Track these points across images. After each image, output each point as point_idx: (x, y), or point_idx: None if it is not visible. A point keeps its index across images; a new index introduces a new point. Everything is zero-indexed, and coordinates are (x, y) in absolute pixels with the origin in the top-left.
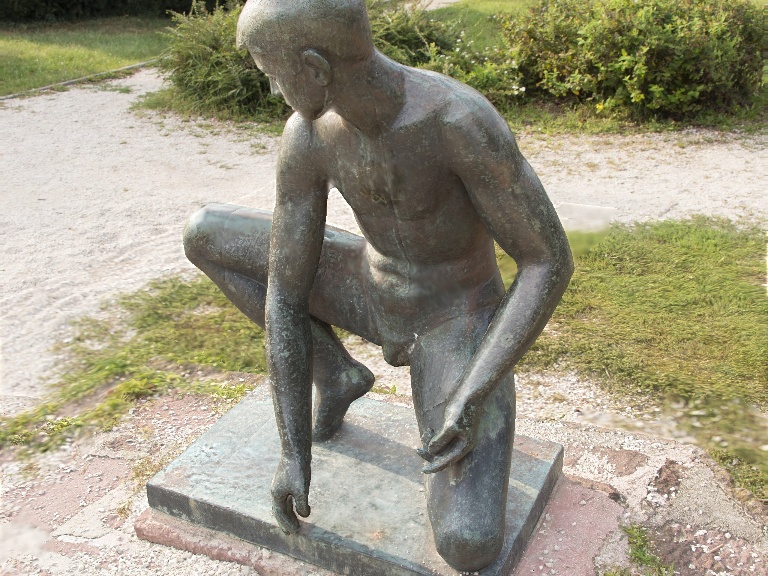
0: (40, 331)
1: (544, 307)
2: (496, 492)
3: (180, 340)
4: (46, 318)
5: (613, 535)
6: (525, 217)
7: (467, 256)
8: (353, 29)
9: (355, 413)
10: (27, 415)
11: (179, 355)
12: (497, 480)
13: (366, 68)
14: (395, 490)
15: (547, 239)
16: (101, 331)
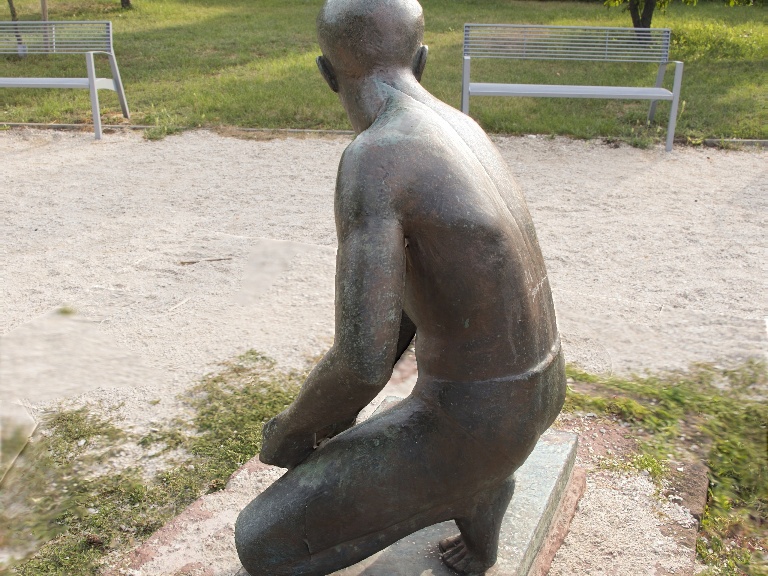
0: (721, 349)
1: (313, 382)
2: (266, 520)
3: (765, 428)
4: (744, 345)
5: None
6: (336, 282)
7: (426, 334)
8: (339, 45)
9: (516, 492)
10: (575, 372)
11: (727, 430)
12: (274, 514)
13: (358, 87)
14: None
15: (338, 318)
16: (746, 379)
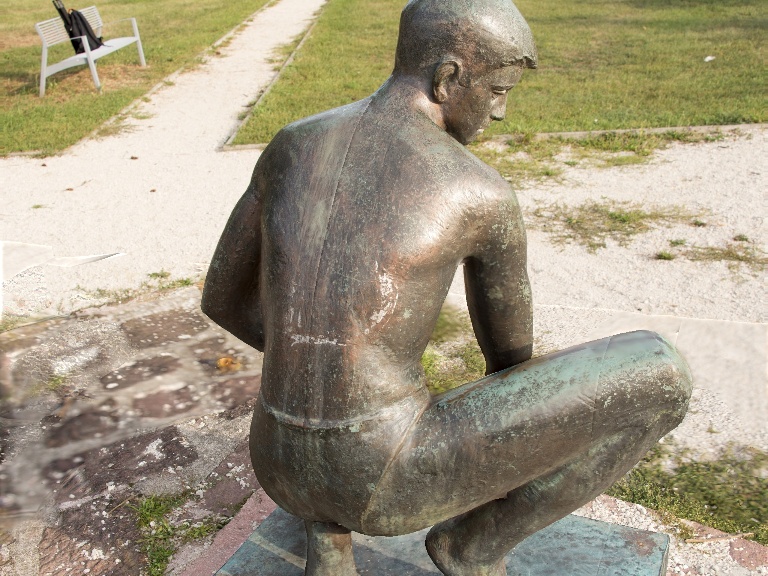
0: None
1: None
2: None
3: None
4: None
5: (178, 572)
6: None
7: None
8: None
9: None
10: None
11: None
12: None
13: None
14: (398, 541)
15: None
16: None
